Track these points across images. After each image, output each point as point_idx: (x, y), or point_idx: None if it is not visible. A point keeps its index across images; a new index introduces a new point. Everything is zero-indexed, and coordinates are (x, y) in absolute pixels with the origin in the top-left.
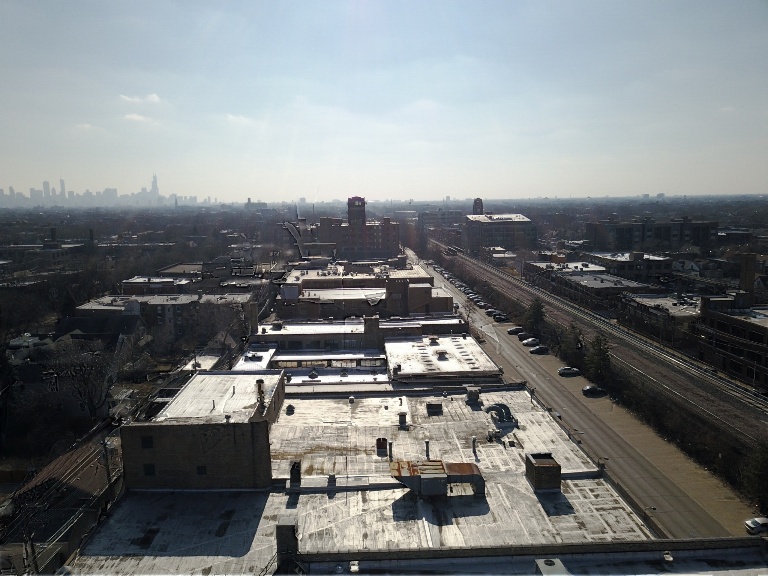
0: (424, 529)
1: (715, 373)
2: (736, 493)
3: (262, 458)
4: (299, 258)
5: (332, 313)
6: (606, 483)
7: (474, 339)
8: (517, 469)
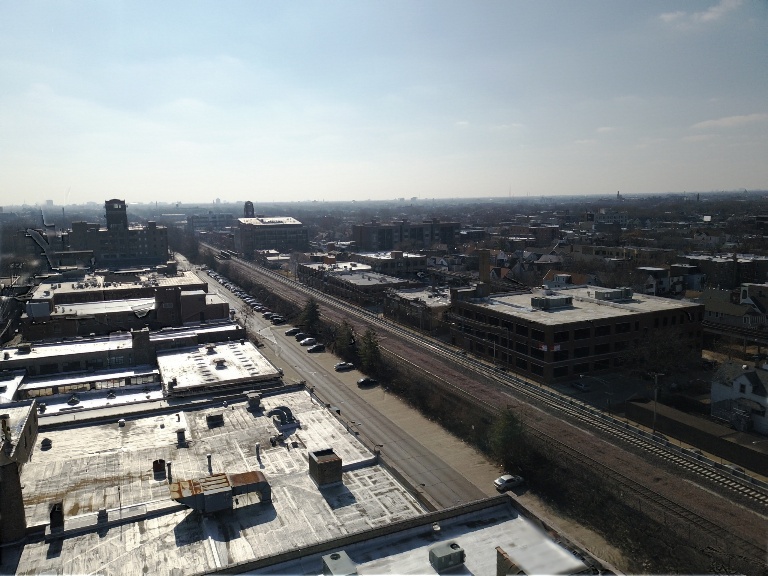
0: (210, 548)
1: (465, 355)
2: (486, 457)
3: (12, 506)
4: (48, 270)
5: (93, 329)
6: (382, 468)
7: (252, 344)
8: (301, 469)
